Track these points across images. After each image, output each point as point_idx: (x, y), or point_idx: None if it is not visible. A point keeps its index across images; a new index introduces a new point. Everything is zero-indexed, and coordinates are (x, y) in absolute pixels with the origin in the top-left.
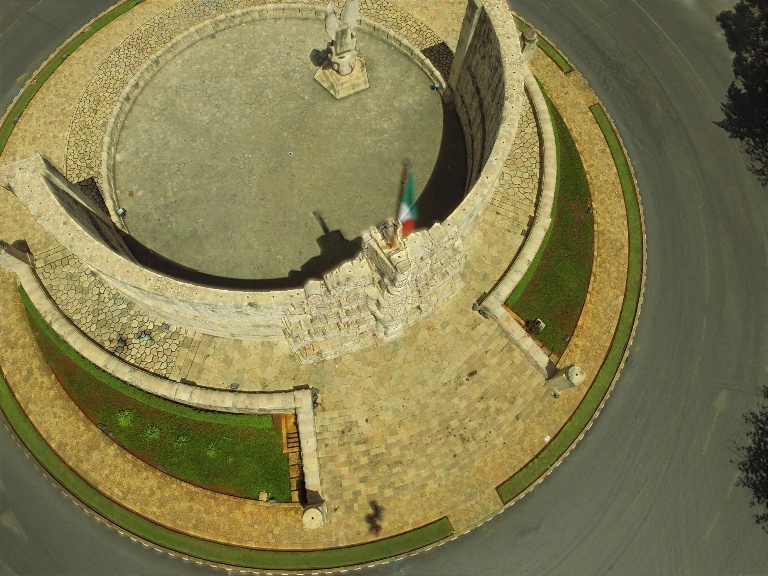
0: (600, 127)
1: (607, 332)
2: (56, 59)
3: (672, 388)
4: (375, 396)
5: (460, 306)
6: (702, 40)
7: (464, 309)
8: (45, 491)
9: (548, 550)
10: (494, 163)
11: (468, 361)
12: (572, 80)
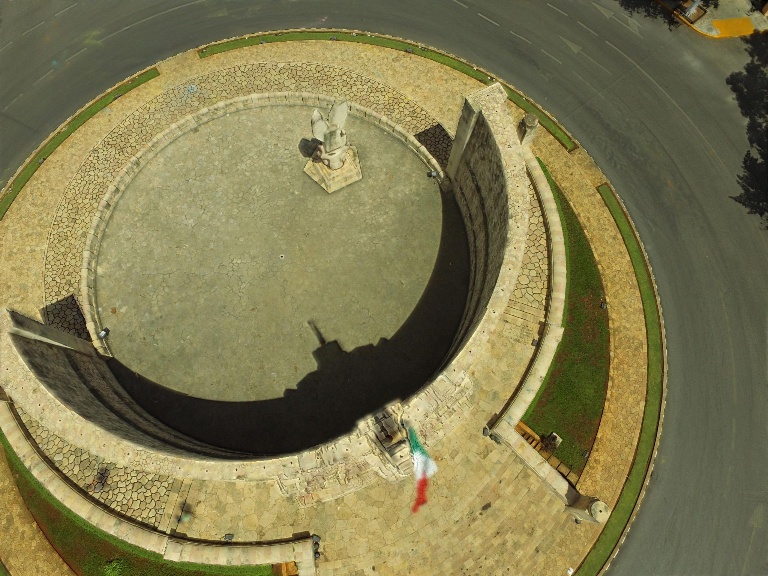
0: (609, 210)
1: (629, 444)
2: (32, 164)
3: (703, 504)
4: (381, 541)
5: (469, 431)
6: (713, 106)
7: (474, 434)
8: None
9: None
10: (501, 294)
11: (481, 494)
12: (577, 158)
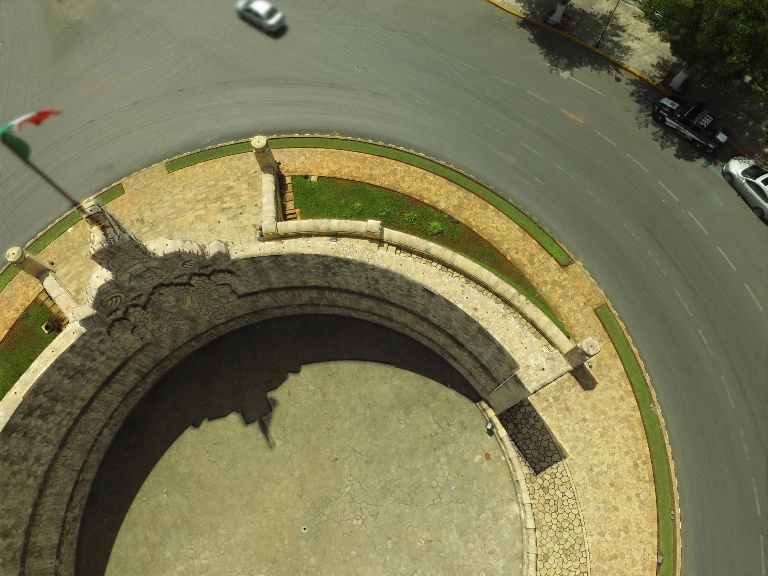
0: None
1: None
2: None
3: None
4: (209, 238)
5: None
6: None
7: None
8: (488, 177)
9: (93, 156)
10: (2, 414)
11: None
12: None
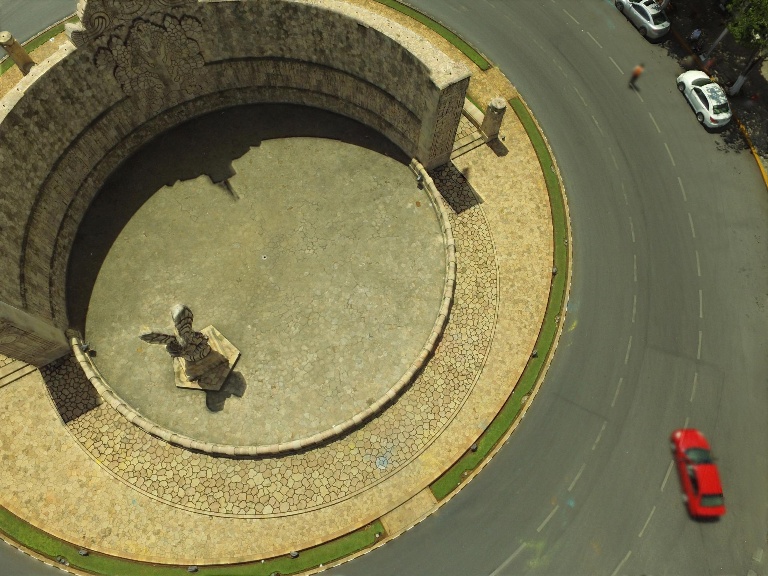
0: None
1: None
2: (545, 351)
3: None
4: None
5: None
6: None
7: None
8: (422, 5)
9: None
10: (7, 103)
11: None
12: None
